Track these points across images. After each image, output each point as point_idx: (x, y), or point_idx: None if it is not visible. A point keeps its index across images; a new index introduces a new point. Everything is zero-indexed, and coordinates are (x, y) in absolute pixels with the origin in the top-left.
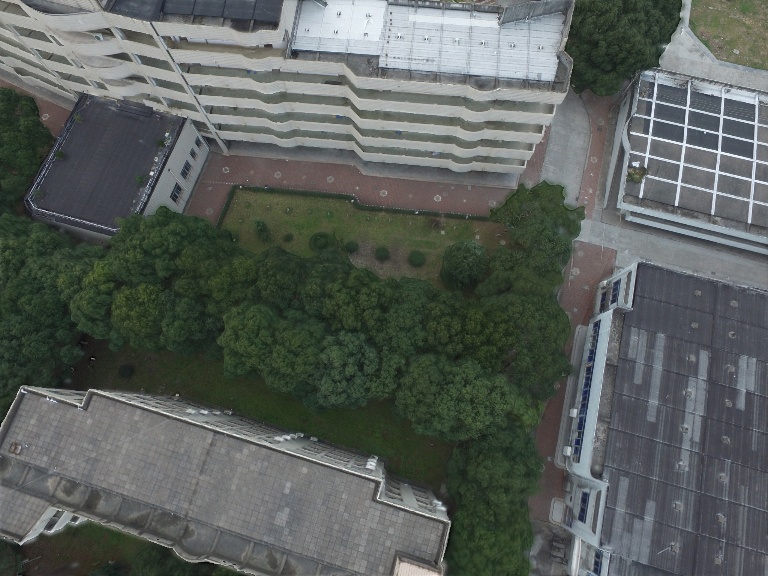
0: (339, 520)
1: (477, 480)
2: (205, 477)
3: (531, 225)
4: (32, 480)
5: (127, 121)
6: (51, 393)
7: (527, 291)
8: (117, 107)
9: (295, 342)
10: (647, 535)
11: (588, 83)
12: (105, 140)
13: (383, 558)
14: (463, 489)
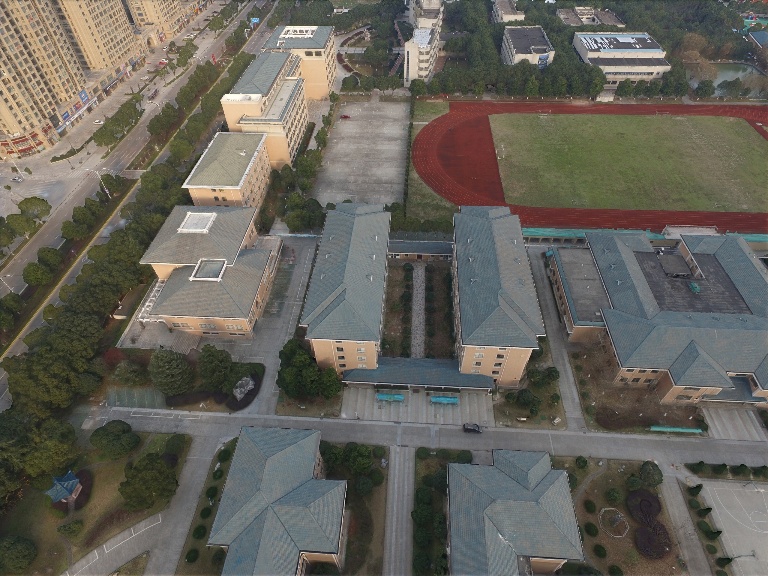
0: None
1: None
2: None
3: (445, 2)
4: (515, 14)
5: (443, 37)
6: None
7: None
8: (440, 38)
9: None
10: None
11: (405, 8)
12: None
13: None
14: (491, 5)
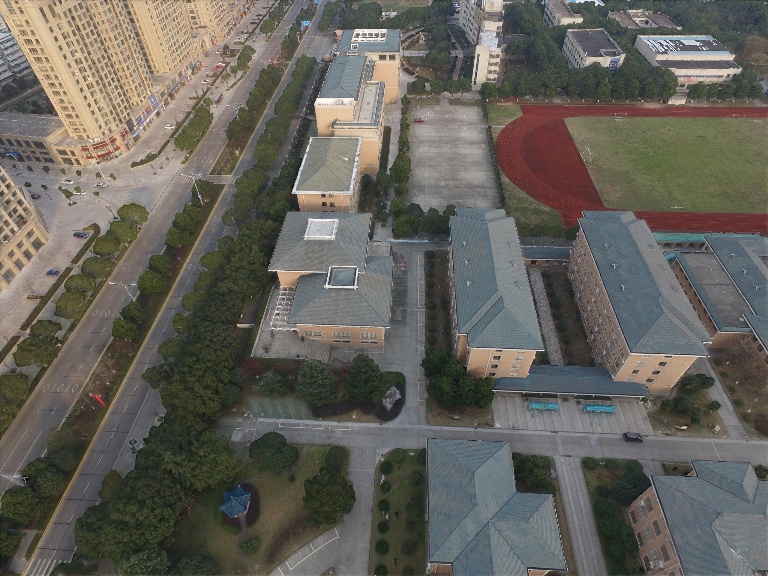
0: (555, 2)
1: (539, 6)
2: (559, 8)
3: None
4: None
5: None
6: (560, 17)
7: (507, 4)
8: None
9: (534, 8)
10: (535, 0)
11: (454, 11)
12: (507, 41)
13: (556, 0)
14: (541, 8)
